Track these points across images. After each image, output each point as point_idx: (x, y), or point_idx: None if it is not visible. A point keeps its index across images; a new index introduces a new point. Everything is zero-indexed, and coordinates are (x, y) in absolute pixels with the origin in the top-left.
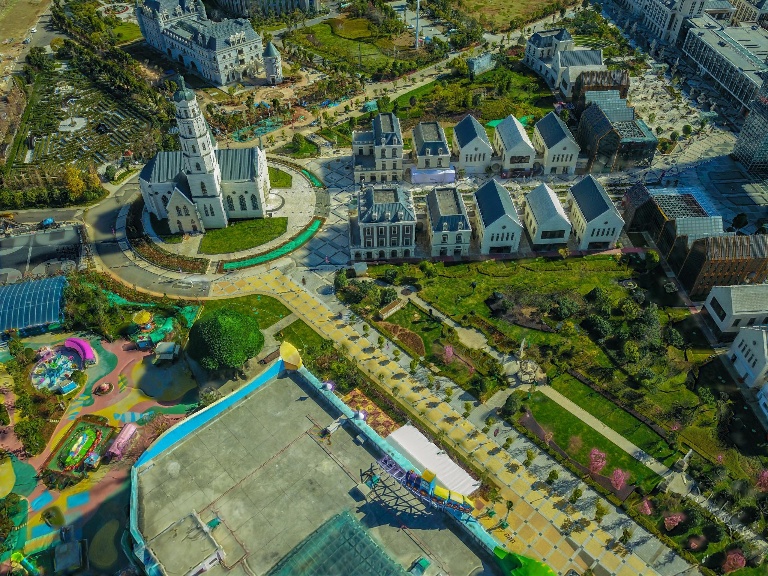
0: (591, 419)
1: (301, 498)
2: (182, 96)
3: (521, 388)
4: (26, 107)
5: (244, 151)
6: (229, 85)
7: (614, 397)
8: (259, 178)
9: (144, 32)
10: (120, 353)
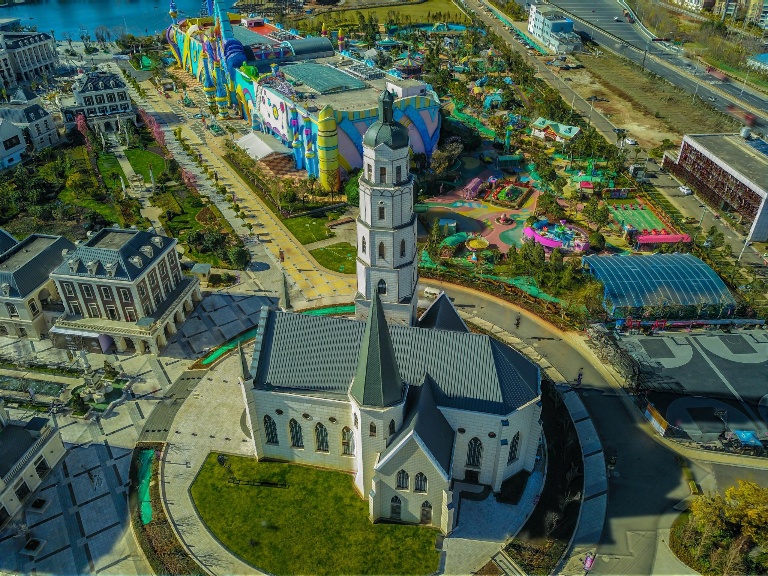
0: (127, 170)
1: None
2: None
3: None
4: None
5: None
6: None
7: (96, 173)
8: None
9: None
10: (499, 243)
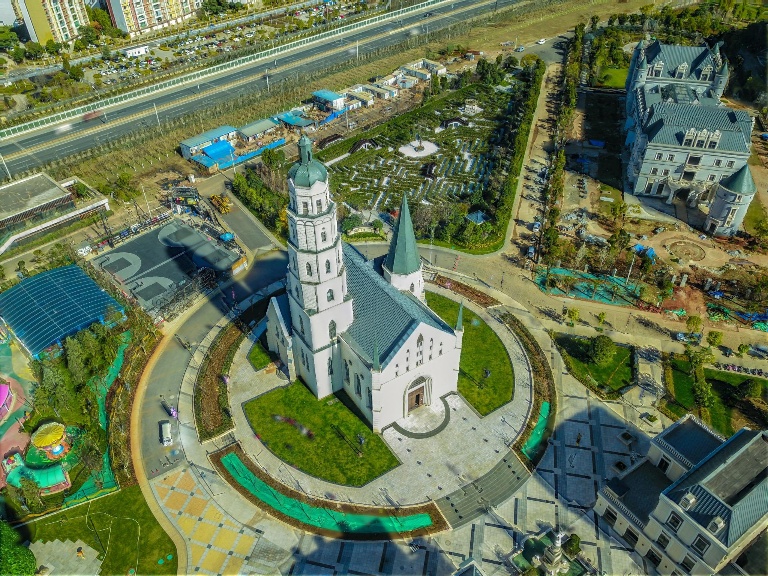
0: None
1: None
2: (293, 172)
3: None
4: (413, 110)
5: (402, 314)
6: (643, 198)
7: None
8: (377, 373)
9: (628, 83)
10: None
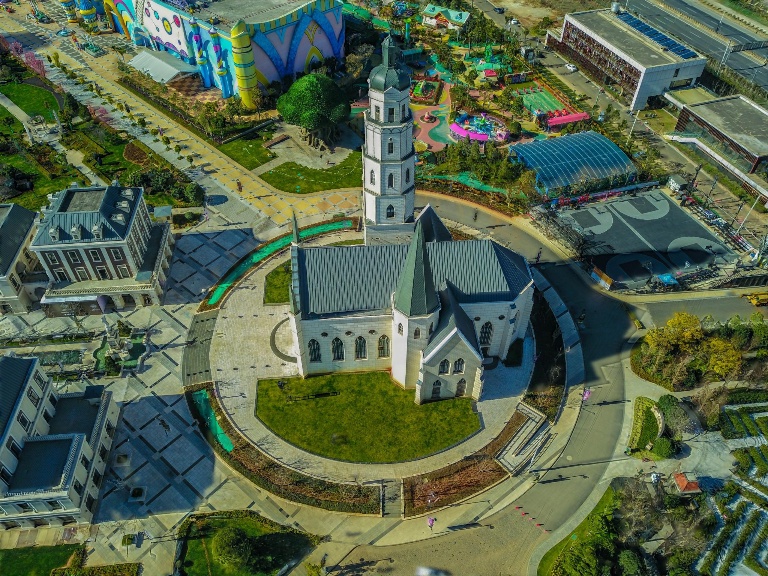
0: (14, 110)
1: (238, 5)
2: None
3: (54, 125)
4: None
5: None
6: None
7: None
8: None
9: None
10: (431, 142)
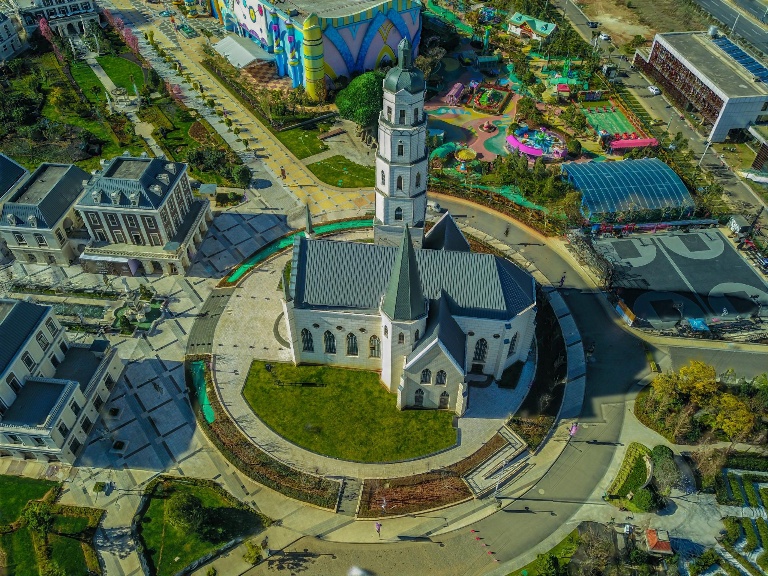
0: (105, 80)
1: None
2: None
3: (135, 98)
4: None
5: None
6: None
7: (74, 85)
8: None
9: None
10: (484, 152)
